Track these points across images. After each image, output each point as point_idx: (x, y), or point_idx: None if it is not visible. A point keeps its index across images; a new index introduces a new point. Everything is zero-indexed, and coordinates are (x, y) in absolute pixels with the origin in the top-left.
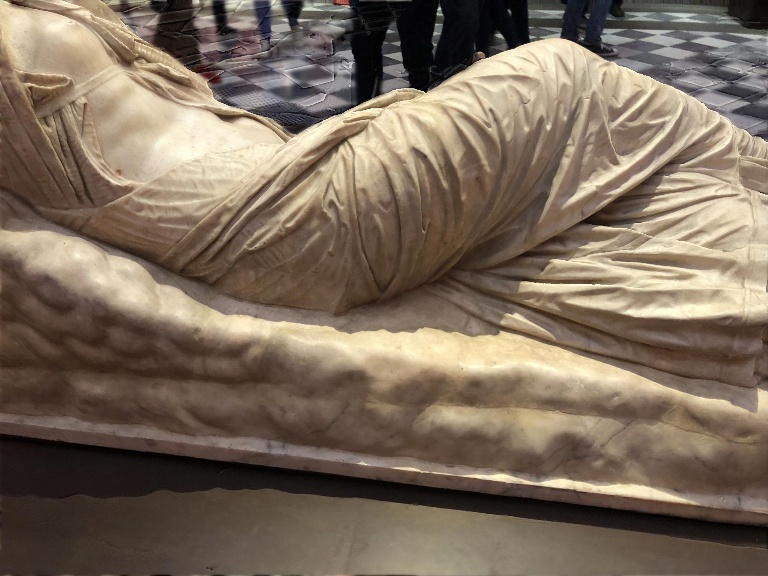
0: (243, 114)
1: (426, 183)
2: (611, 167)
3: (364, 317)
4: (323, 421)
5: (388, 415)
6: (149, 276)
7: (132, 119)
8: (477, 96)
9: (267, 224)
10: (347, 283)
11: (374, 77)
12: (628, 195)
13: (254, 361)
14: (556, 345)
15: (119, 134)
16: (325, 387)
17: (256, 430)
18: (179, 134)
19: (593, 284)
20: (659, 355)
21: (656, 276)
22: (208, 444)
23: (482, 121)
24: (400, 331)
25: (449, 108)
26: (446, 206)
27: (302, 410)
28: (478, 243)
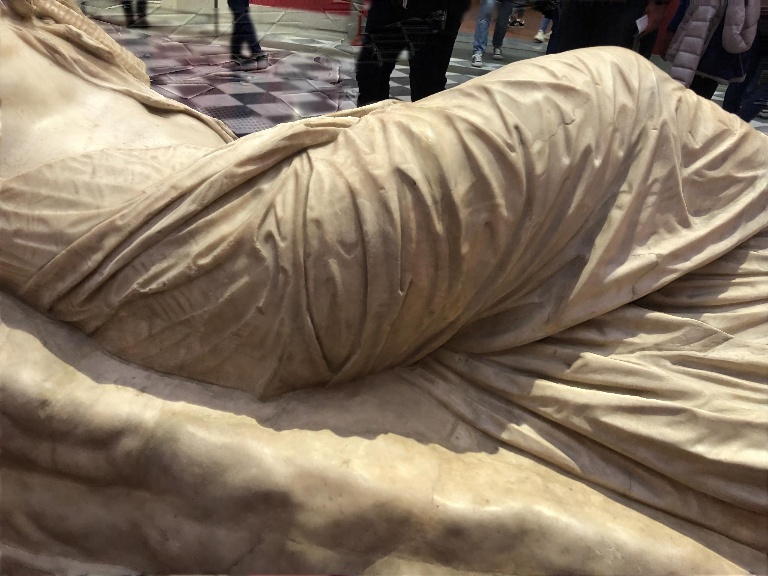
0: (183, 110)
1: (411, 222)
2: (679, 230)
3: (304, 407)
4: (220, 561)
5: (318, 564)
6: None
7: (6, 88)
8: (498, 106)
9: (171, 257)
10: (281, 356)
11: None
12: (697, 273)
13: (126, 459)
14: (580, 480)
15: None
16: (228, 510)
17: (126, 557)
18: (75, 119)
19: (643, 397)
20: (738, 519)
21: (739, 396)
22: (53, 570)
23: (502, 141)
24: (352, 435)
25: (456, 118)
26: (438, 259)
27: (191, 540)
28: (480, 317)
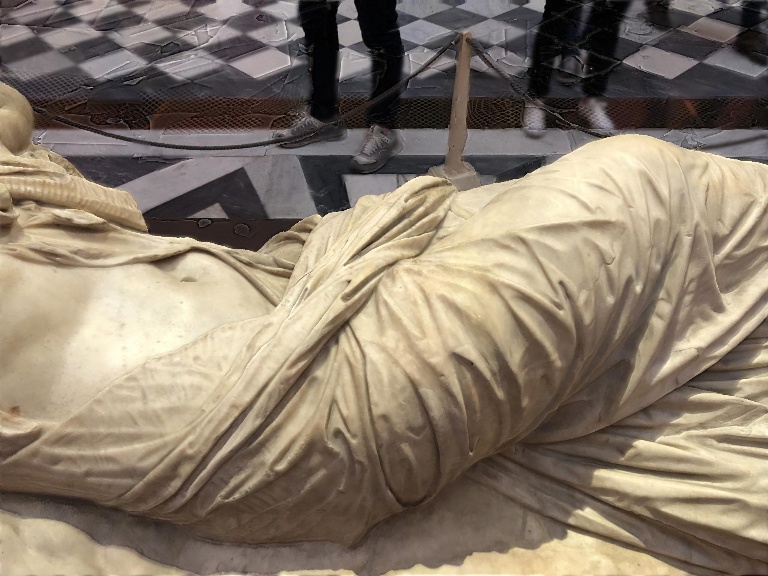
0: (190, 249)
1: (473, 397)
2: (715, 317)
3: (390, 543)
4: None
5: None
6: (86, 538)
7: (25, 325)
8: (539, 260)
9: (247, 467)
10: (367, 520)
11: (339, 58)
12: None
13: None
14: (645, 552)
15: (8, 354)
16: None
17: None
18: (100, 326)
19: (696, 481)
20: None
21: None
22: None
23: (549, 301)
24: (442, 564)
25: (500, 285)
26: (501, 417)
27: None
28: None
